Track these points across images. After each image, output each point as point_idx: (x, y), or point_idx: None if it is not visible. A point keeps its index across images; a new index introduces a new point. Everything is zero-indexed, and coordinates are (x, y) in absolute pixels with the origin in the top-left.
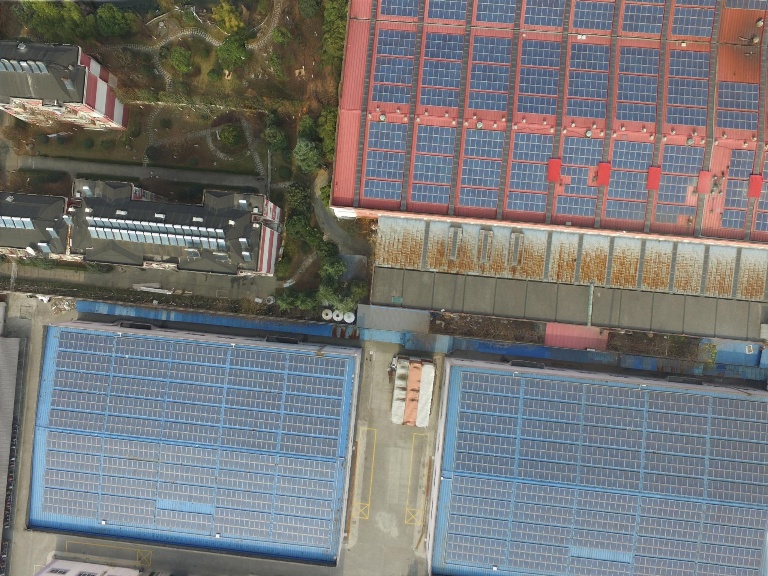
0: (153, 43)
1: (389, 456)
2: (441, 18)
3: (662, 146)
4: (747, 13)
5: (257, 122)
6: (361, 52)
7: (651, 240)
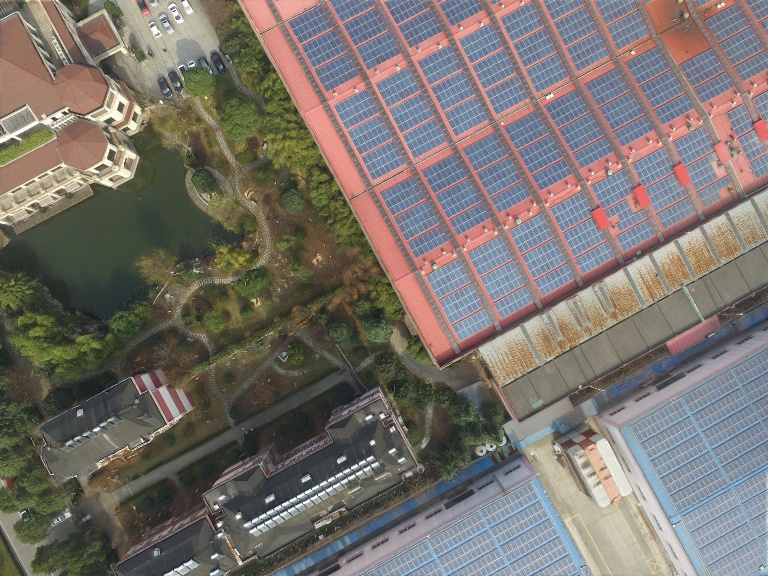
0: (170, 317)
1: (603, 529)
2: (426, 152)
3: (672, 145)
4: None
5: (313, 328)
6: (378, 222)
7: None
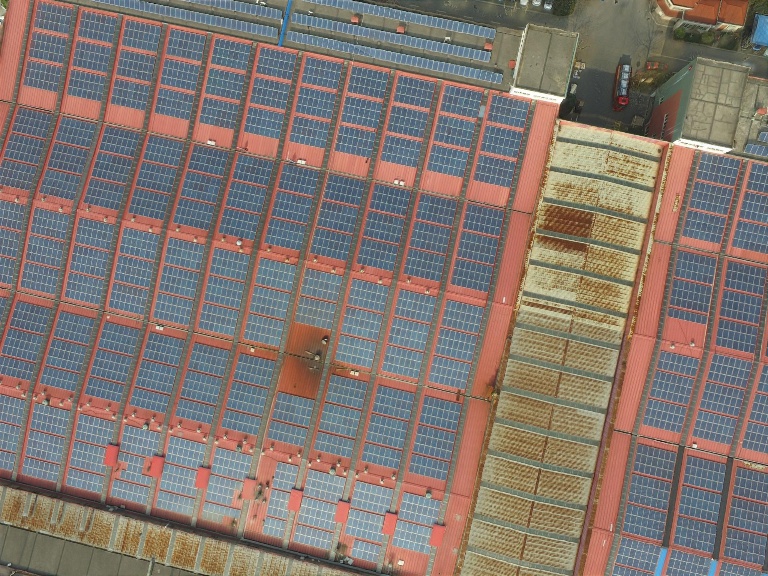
0: None
1: None
2: (33, 289)
3: (214, 448)
4: (315, 329)
5: None
6: None
7: None
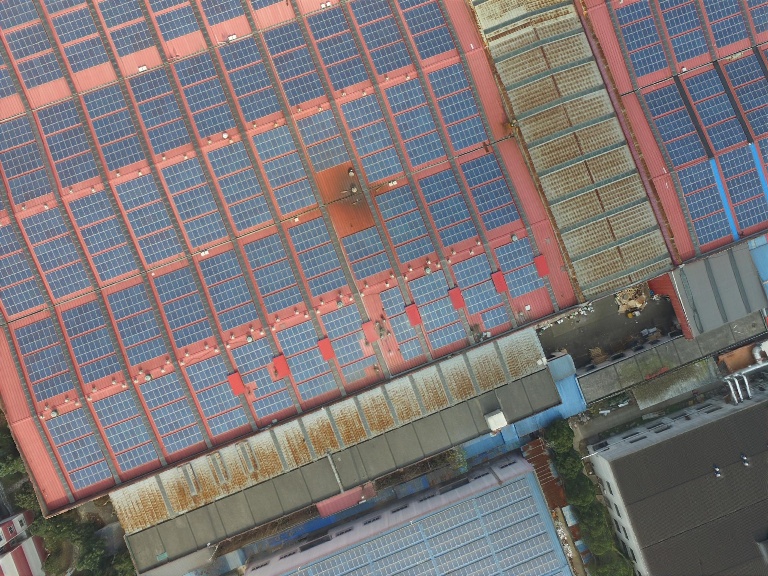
0: None
1: None
2: (68, 294)
3: (319, 318)
4: (337, 169)
5: None
6: (7, 360)
7: None
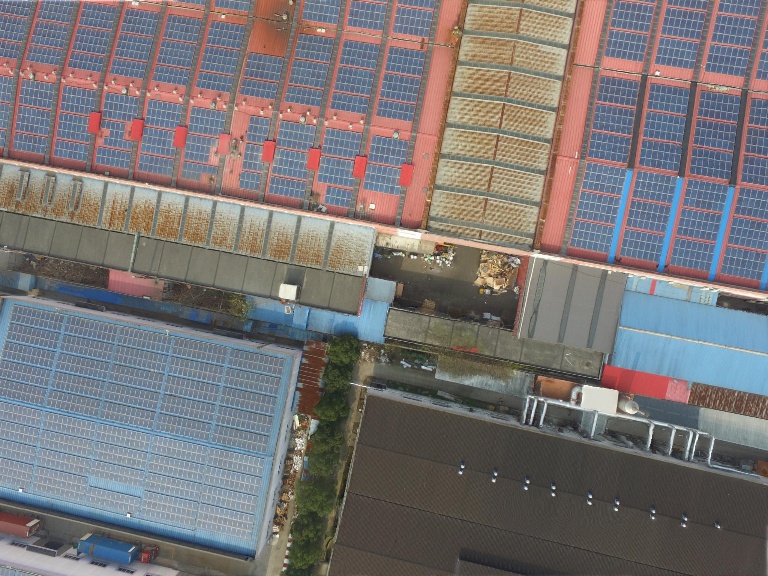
0: None
1: None
2: None
3: (190, 108)
4: None
5: None
6: None
7: (194, 197)
